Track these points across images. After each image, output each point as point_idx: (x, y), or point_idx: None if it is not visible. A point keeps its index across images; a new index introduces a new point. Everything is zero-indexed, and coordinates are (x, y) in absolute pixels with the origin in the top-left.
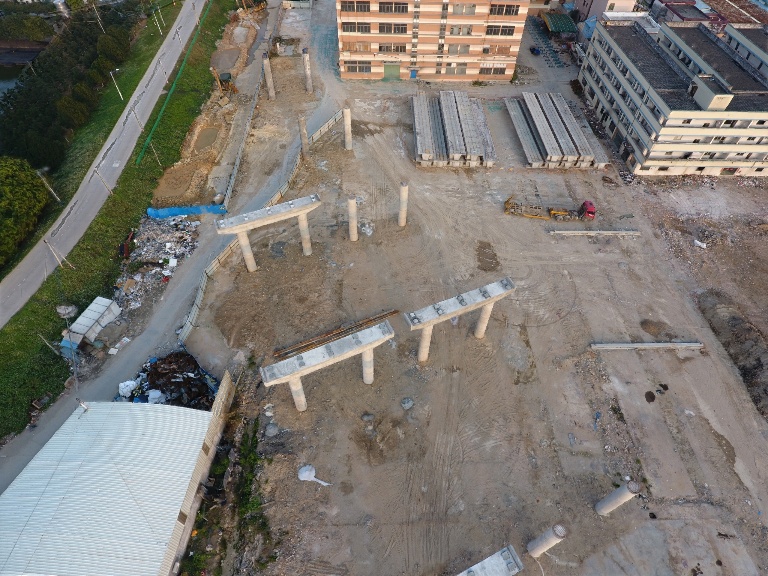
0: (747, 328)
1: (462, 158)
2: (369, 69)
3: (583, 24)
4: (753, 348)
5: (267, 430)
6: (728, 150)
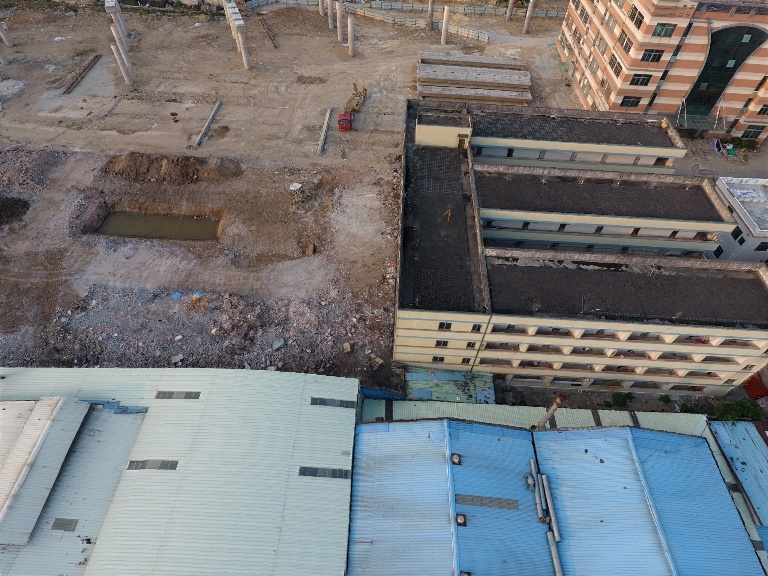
0: (190, 159)
1: None
2: None
3: None
4: None
5: (223, 17)
6: None
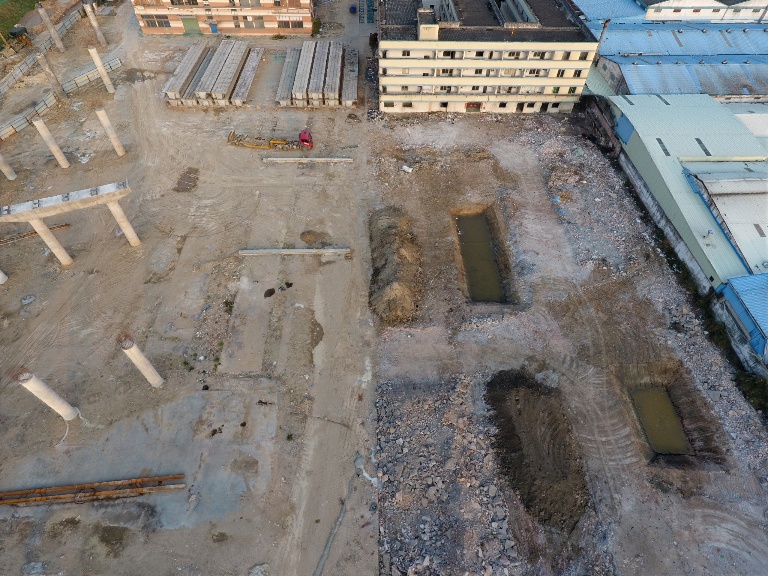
0: (392, 234)
1: (210, 97)
2: (168, 24)
3: None
4: (387, 250)
5: None
6: (456, 83)
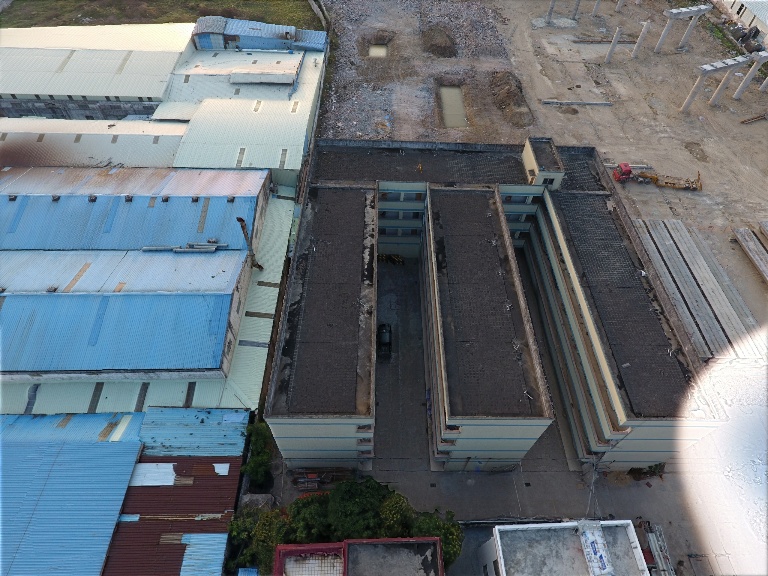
0: None
1: None
2: None
3: None
4: None
5: None
6: None
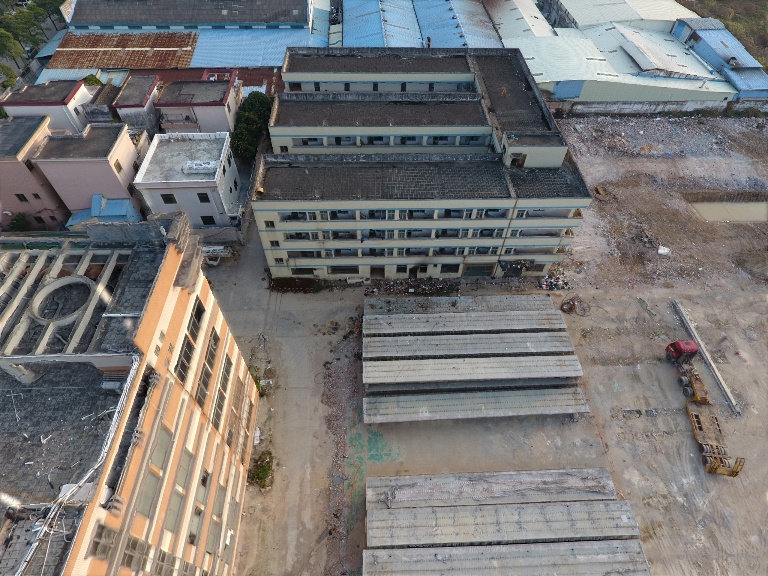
0: None
1: None
2: None
3: (92, 221)
4: None
5: None
6: None
